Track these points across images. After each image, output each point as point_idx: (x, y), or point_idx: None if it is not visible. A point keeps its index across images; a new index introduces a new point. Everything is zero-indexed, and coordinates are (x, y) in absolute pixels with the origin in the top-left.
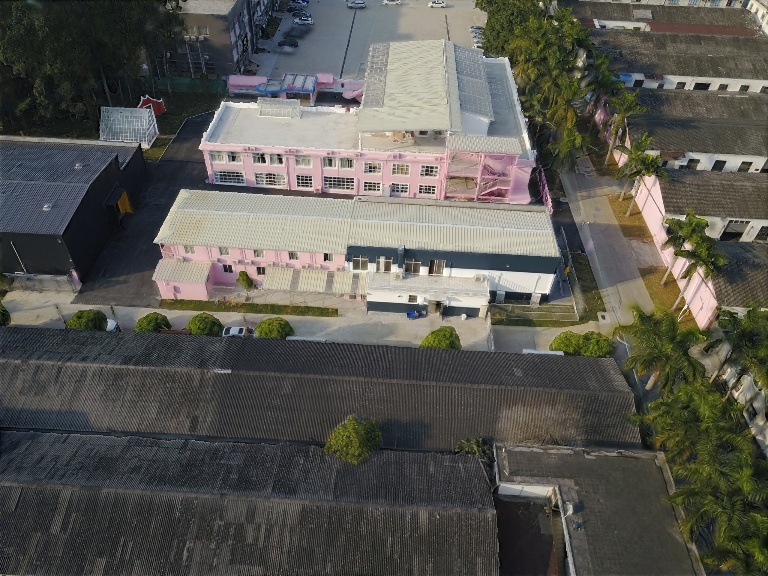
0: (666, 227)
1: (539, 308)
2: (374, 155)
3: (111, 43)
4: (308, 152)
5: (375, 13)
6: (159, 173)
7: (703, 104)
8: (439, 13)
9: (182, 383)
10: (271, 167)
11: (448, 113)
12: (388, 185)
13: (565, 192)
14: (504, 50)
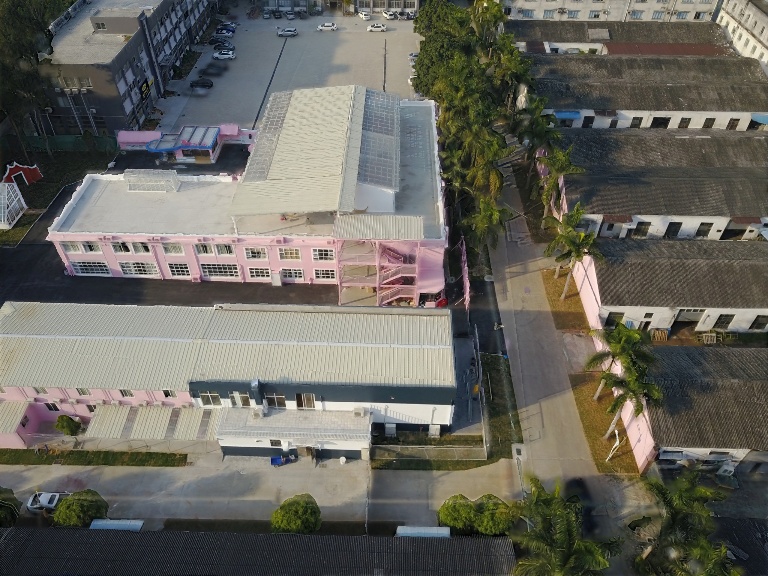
0: (604, 318)
1: (439, 442)
2: (254, 240)
3: None
4: (176, 239)
5: (307, 41)
6: (13, 263)
7: (658, 148)
8: (378, 38)
9: None
10: (136, 256)
11: (339, 187)
12: (278, 271)
13: (492, 267)
14: None
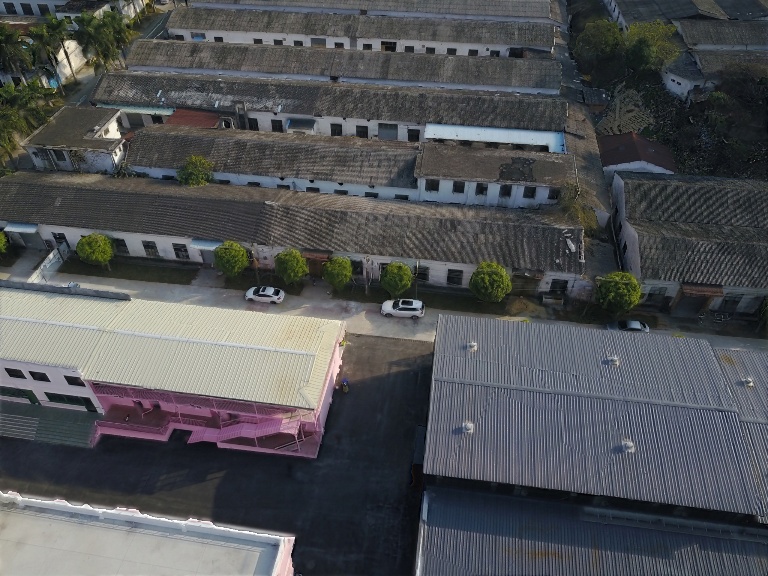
0: None
1: None
2: None
3: None
4: None
5: None
6: None
7: None
8: None
9: None
10: None
11: None
12: None
13: None
14: None
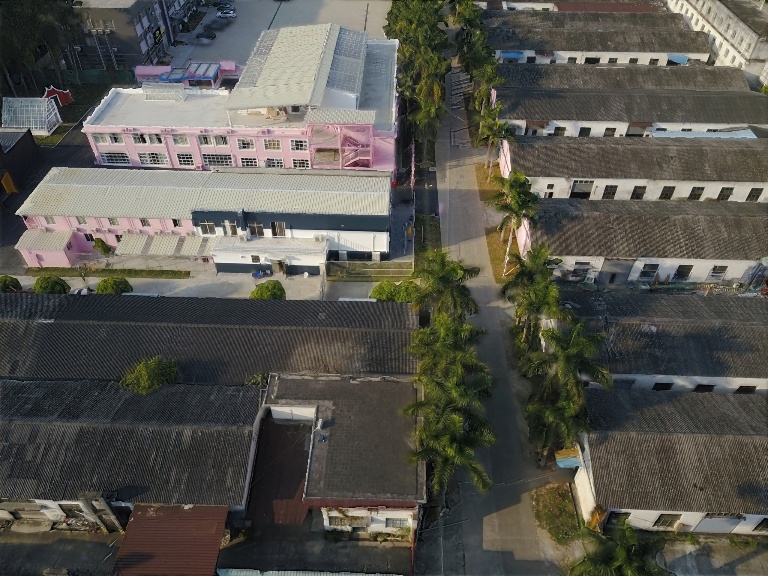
0: None
1: (379, 265)
2: (244, 132)
3: (2, 36)
4: (183, 131)
5: (299, 5)
6: (53, 157)
7: (580, 76)
8: (362, 2)
9: (8, 332)
10: (152, 147)
11: (311, 89)
12: (263, 160)
13: (436, 162)
14: (402, 33)
